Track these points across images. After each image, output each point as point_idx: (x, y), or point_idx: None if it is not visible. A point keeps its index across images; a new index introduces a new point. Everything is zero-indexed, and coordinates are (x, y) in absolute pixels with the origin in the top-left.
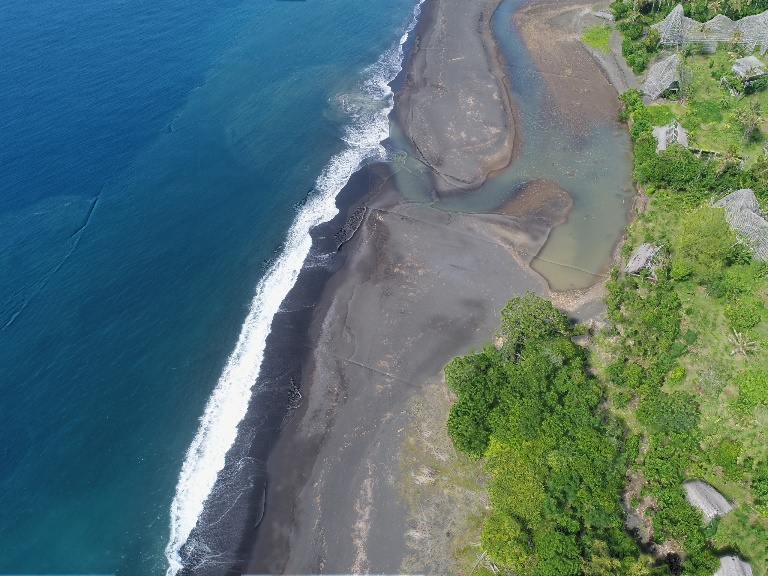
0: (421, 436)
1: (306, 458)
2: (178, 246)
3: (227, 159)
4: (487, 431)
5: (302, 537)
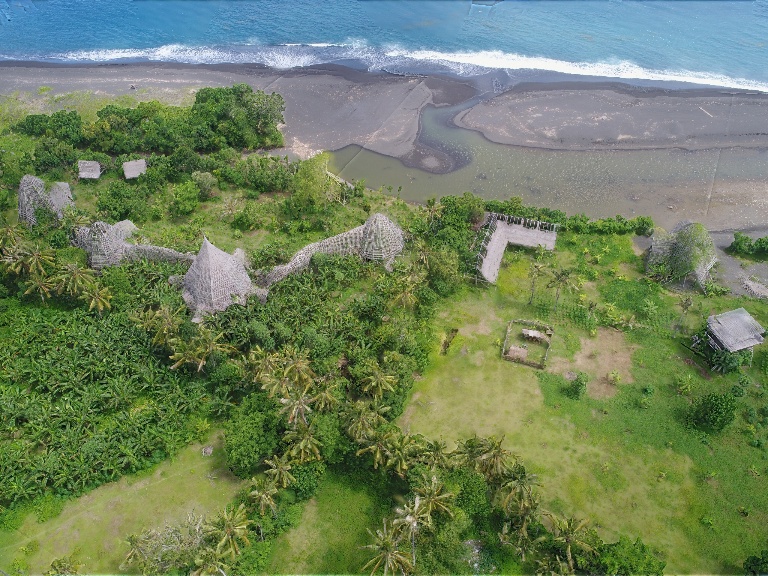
0: None
1: None
2: (358, 2)
3: (453, 5)
4: None
5: (185, 71)
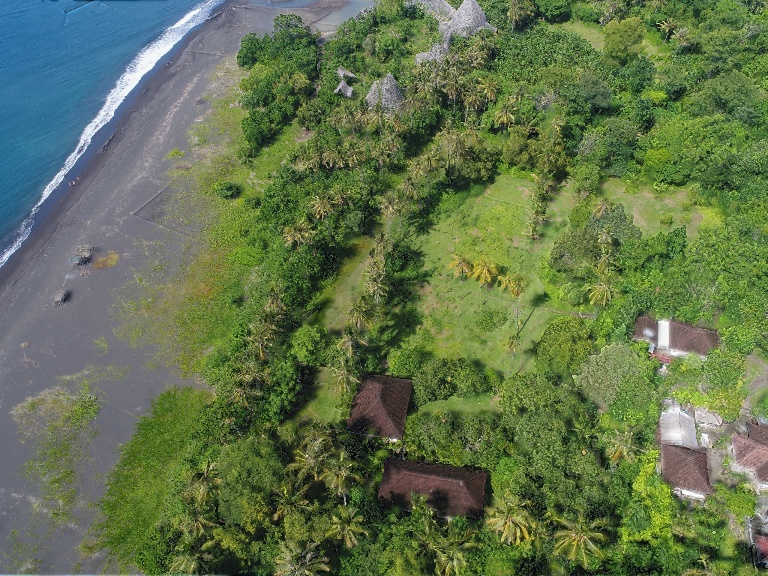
0: None
1: (169, 77)
2: (112, 5)
3: None
4: (256, 61)
5: (161, 94)
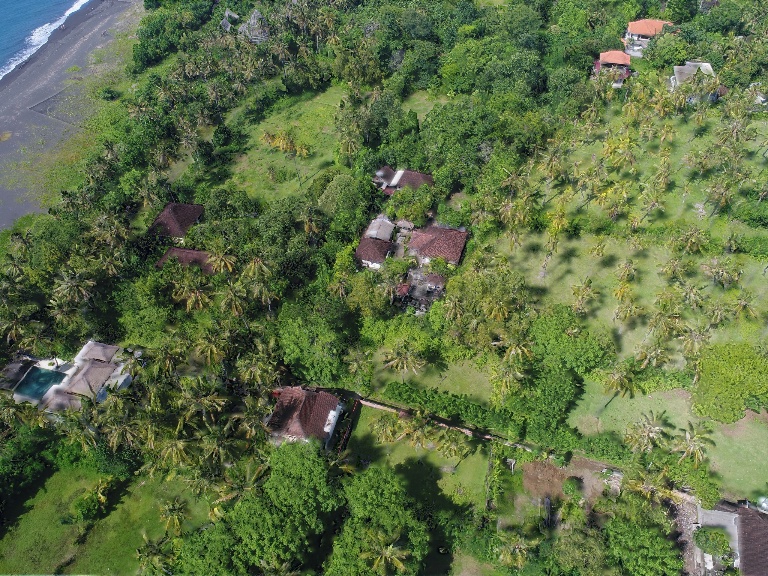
0: (134, 8)
1: (87, 18)
2: None
3: None
4: (160, 6)
5: None
